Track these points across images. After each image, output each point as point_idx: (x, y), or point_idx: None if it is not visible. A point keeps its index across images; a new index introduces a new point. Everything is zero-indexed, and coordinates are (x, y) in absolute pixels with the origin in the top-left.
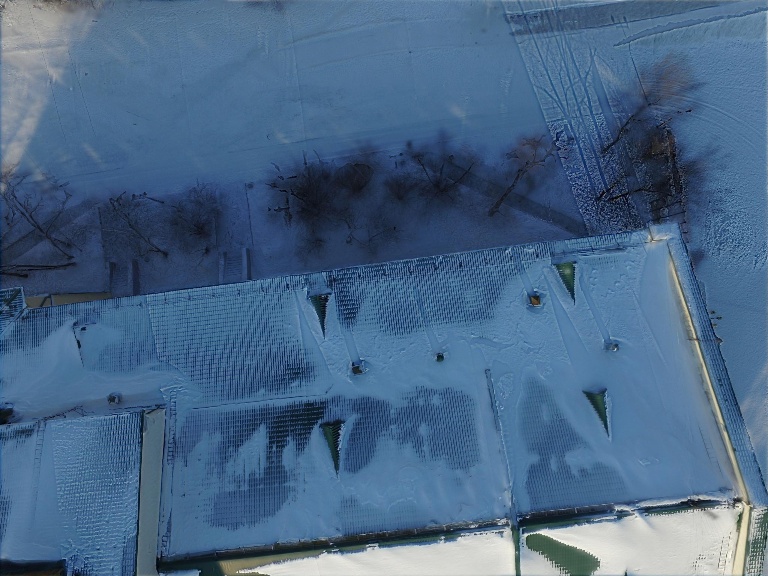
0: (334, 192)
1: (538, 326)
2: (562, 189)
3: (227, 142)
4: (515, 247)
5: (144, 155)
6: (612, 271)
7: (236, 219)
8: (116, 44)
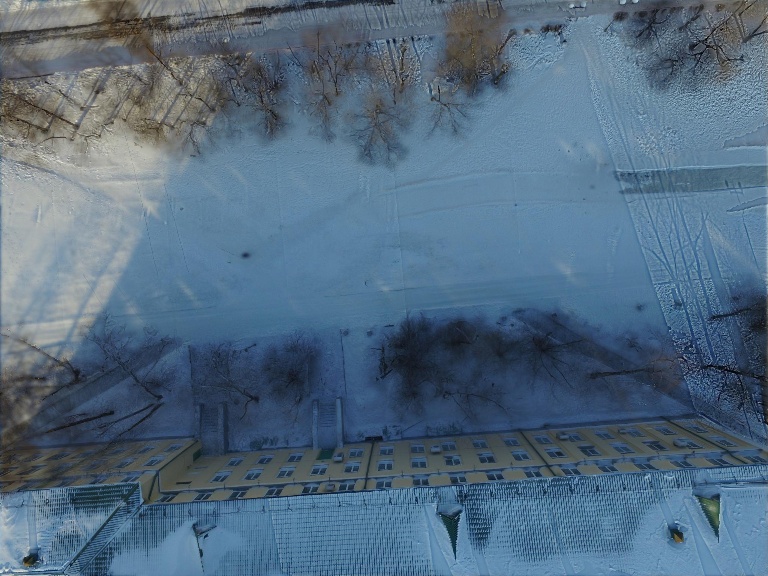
0: (436, 352)
1: (680, 563)
2: (667, 354)
3: (323, 286)
4: (655, 473)
5: (238, 295)
6: (756, 506)
7: (330, 365)
8: (214, 180)
